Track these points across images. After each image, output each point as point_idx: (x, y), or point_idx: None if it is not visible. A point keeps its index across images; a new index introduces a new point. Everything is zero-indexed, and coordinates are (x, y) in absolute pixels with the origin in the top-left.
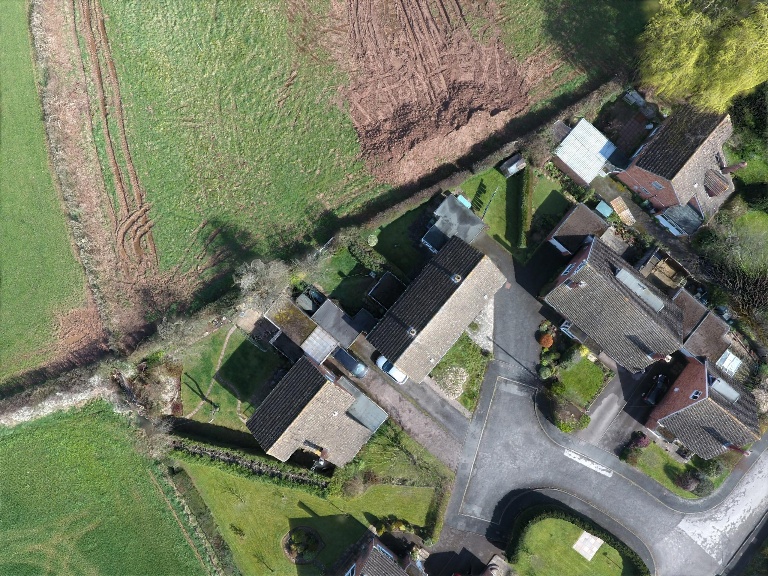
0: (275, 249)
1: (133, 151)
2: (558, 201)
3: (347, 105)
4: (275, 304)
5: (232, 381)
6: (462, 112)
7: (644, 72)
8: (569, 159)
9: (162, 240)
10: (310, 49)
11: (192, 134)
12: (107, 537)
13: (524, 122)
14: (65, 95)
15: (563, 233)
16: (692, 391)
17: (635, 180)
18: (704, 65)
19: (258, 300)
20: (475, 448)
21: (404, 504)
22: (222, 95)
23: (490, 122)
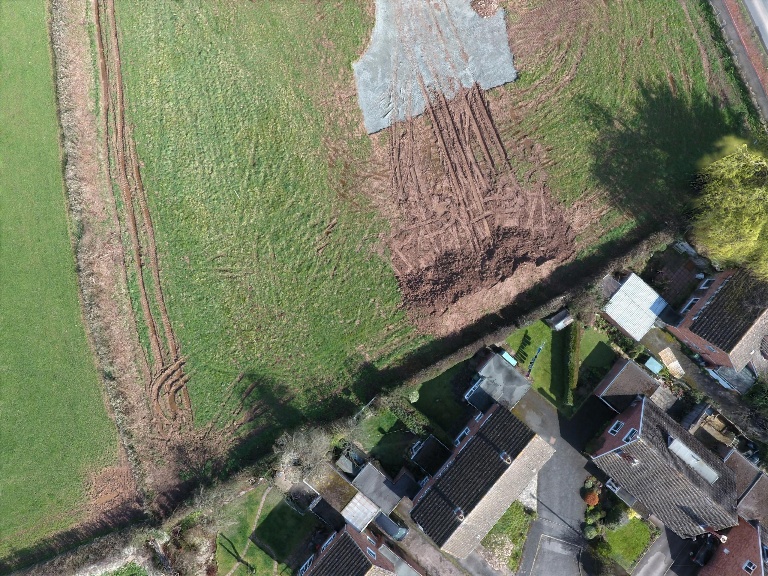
0: (313, 403)
1: (168, 302)
2: (605, 353)
3: (388, 253)
4: (315, 469)
5: (269, 542)
6: (507, 262)
7: (699, 231)
8: (618, 316)
9: (197, 395)
10: (350, 195)
11: (229, 284)
12: None
13: (570, 270)
14: (99, 246)
15: (612, 393)
16: (745, 560)
17: (686, 337)
18: (765, 238)
19: None
20: None
21: None
22: (260, 244)
23: (535, 272)
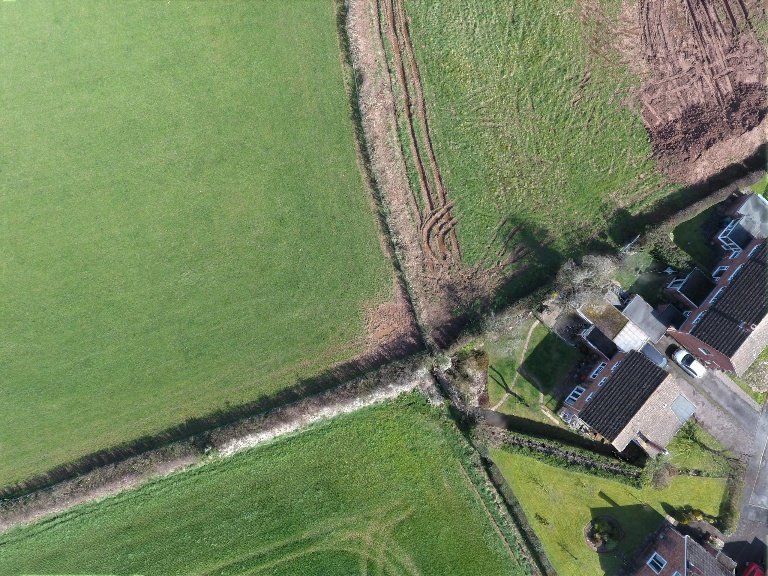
0: (572, 246)
1: (436, 150)
2: None
3: (638, 106)
4: None
5: (535, 374)
6: (753, 113)
7: None
8: None
9: (465, 237)
10: (603, 51)
11: (492, 134)
12: (421, 525)
13: None
14: (373, 95)
15: None
16: None
17: None
18: None
19: (589, 295)
20: (764, 440)
21: (699, 495)
22: (520, 96)
23: None
